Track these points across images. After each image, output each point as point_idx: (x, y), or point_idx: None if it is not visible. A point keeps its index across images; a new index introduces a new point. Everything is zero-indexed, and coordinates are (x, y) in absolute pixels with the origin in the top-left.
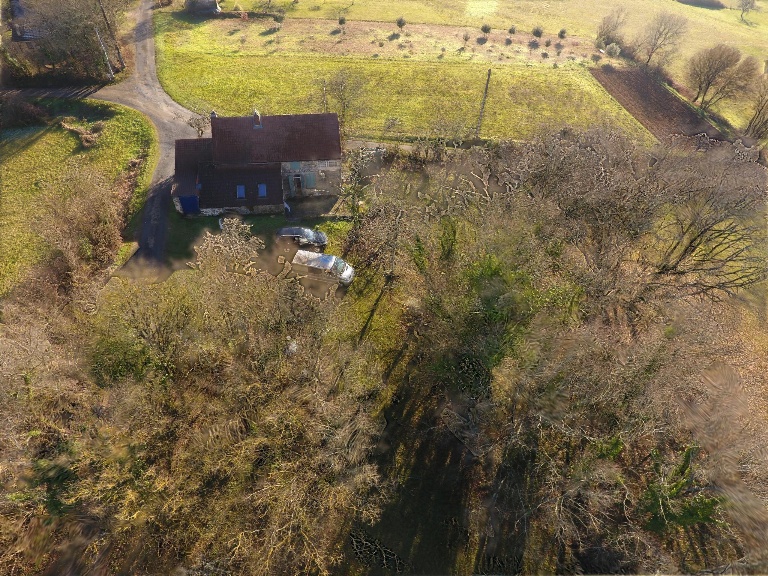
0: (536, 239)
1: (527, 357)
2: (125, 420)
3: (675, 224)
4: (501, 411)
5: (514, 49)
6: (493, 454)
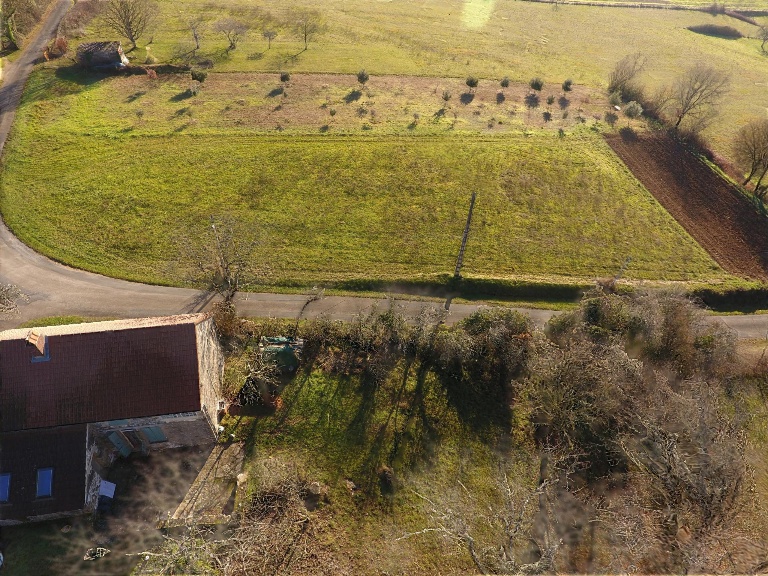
0: None
1: None
2: None
3: None
4: None
5: (508, 109)
6: None
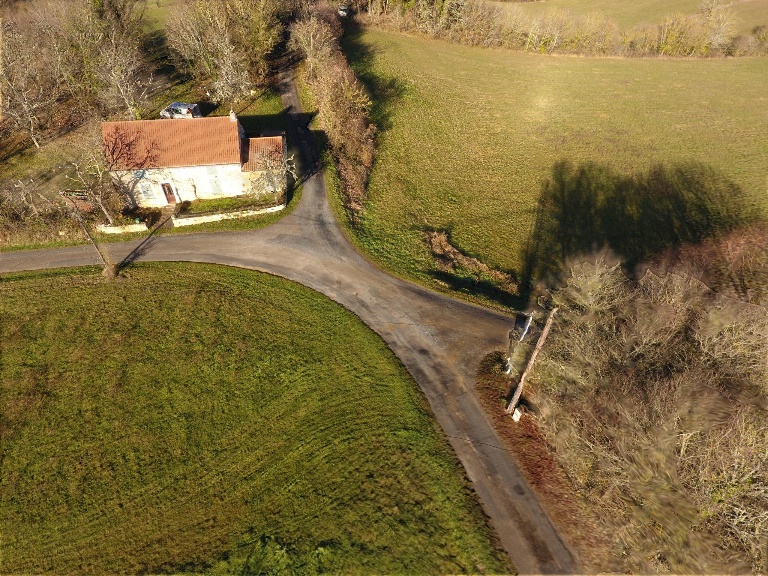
0: None
1: None
2: None
3: None
4: None
5: None
6: None
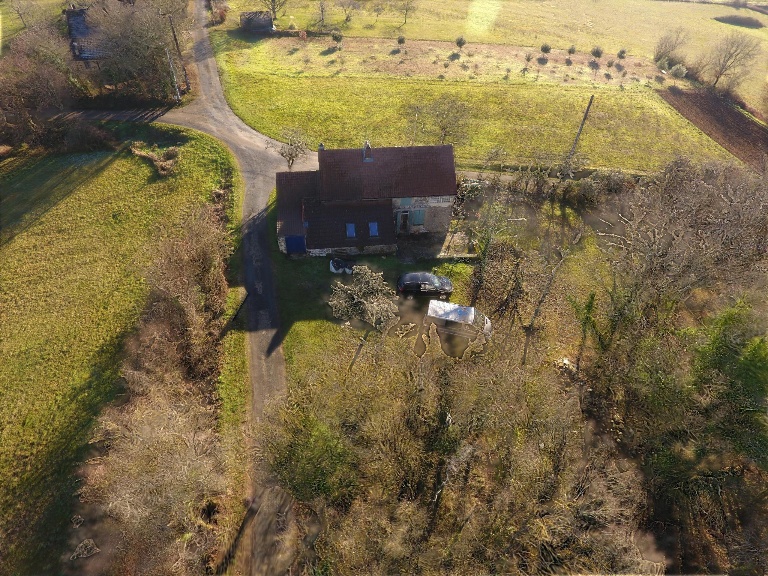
0: None
1: None
2: (396, 575)
3: None
4: None
5: (576, 70)
6: (717, 560)
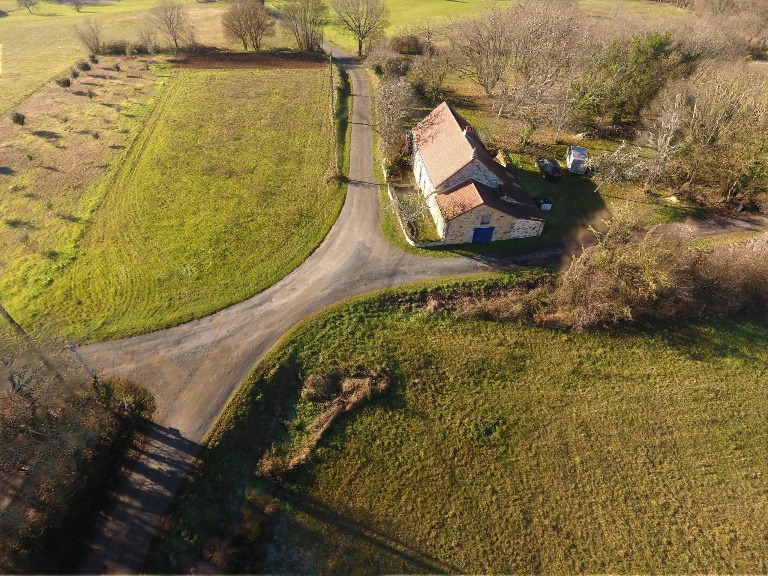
0: None
1: (703, 42)
2: None
3: None
4: None
5: (115, 85)
6: (660, 123)
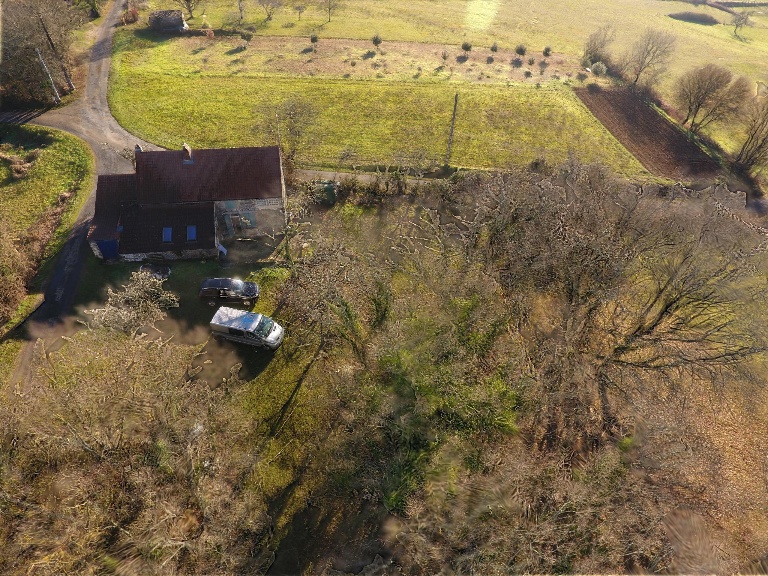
0: (458, 330)
1: (430, 505)
2: None
3: (651, 279)
4: (398, 574)
5: (495, 68)
6: None
